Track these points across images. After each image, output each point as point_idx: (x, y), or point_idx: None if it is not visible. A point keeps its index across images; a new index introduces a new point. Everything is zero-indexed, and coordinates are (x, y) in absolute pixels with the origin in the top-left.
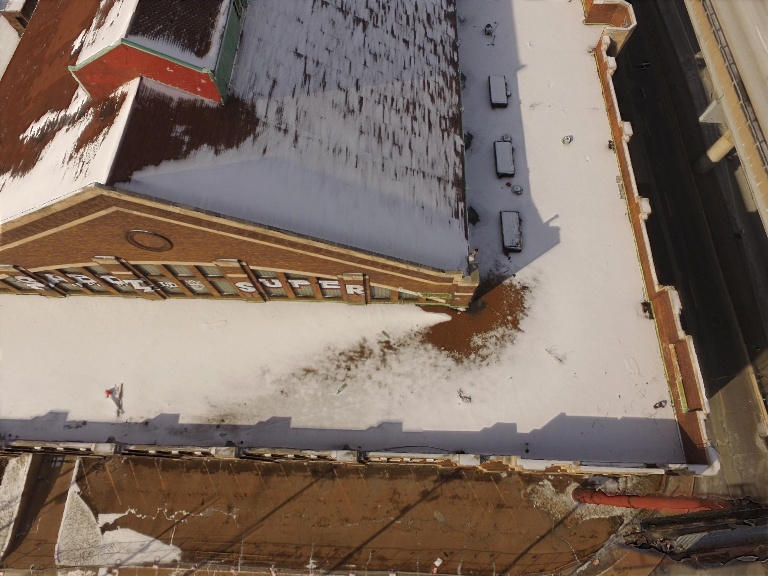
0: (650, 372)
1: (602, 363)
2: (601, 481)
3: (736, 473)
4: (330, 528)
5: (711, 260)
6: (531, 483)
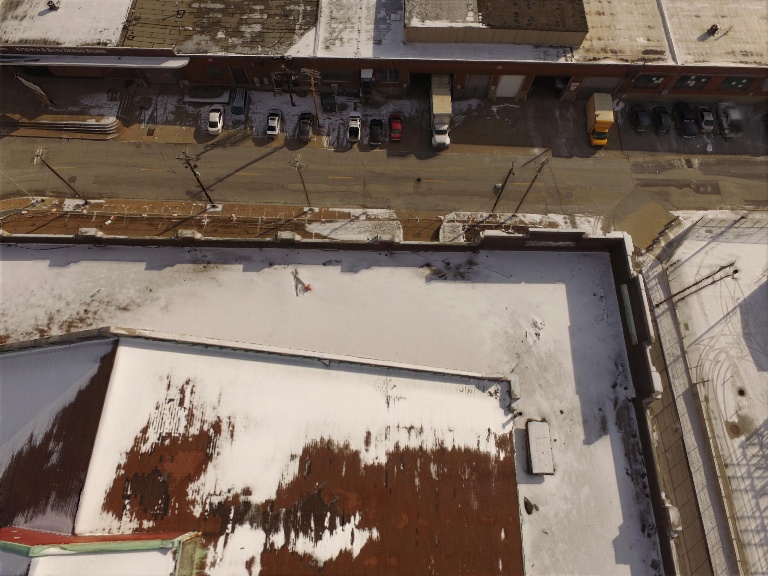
0: None
1: None
2: None
3: None
4: None
5: None
6: None
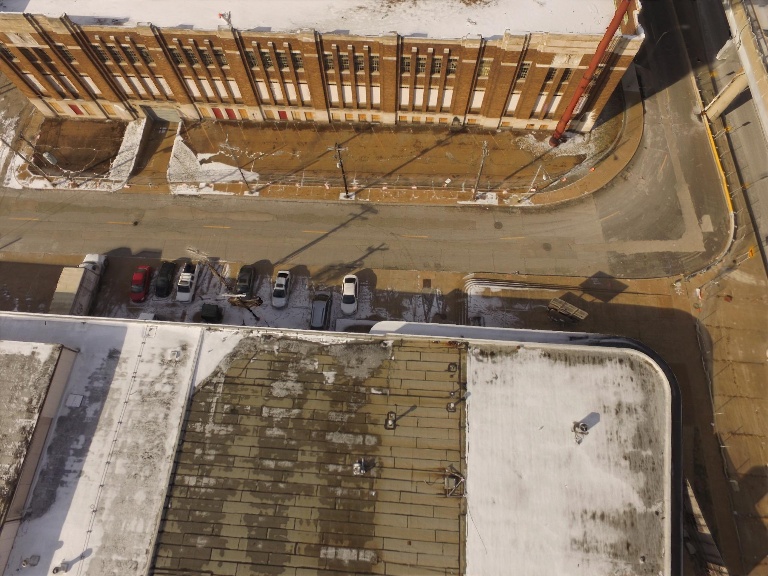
0: (605, 12)
1: (571, 7)
2: (571, 135)
3: (673, 134)
4: (369, 162)
5: (669, 10)
6: (519, 136)
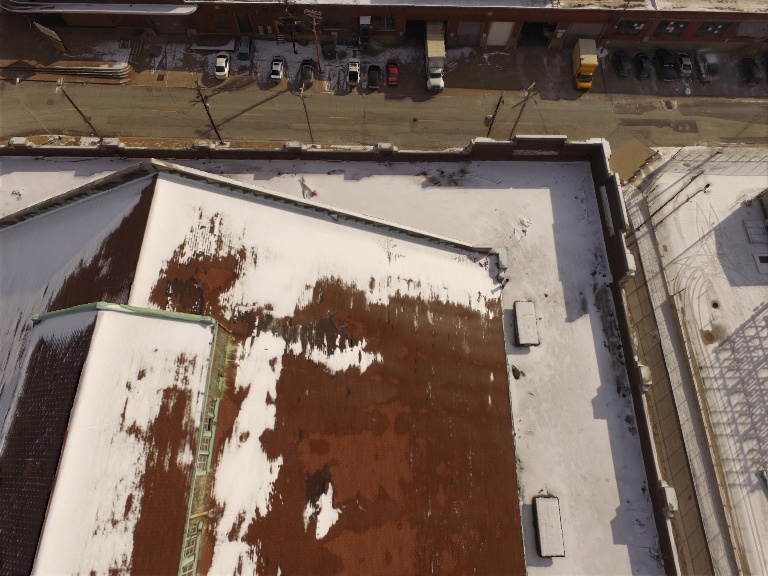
0: None
1: None
2: None
3: None
4: None
5: None
6: None
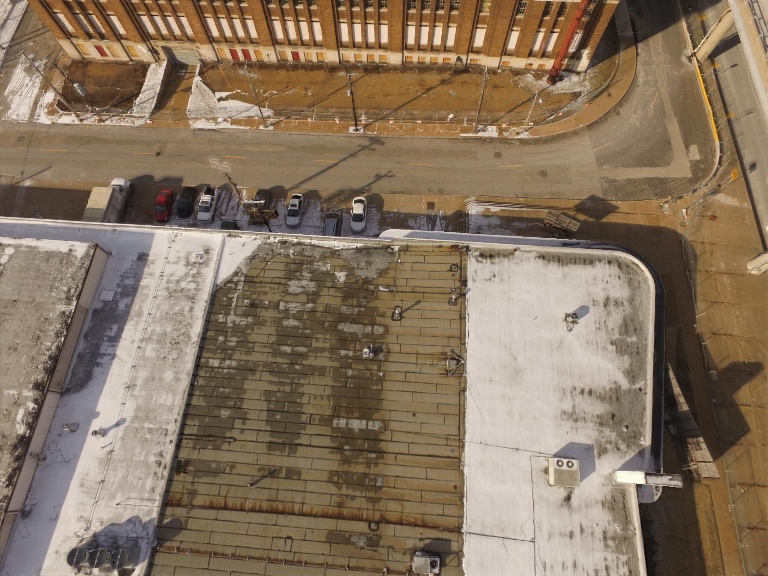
0: None
1: None
2: (568, 75)
3: (664, 74)
4: (376, 99)
5: None
6: (518, 75)
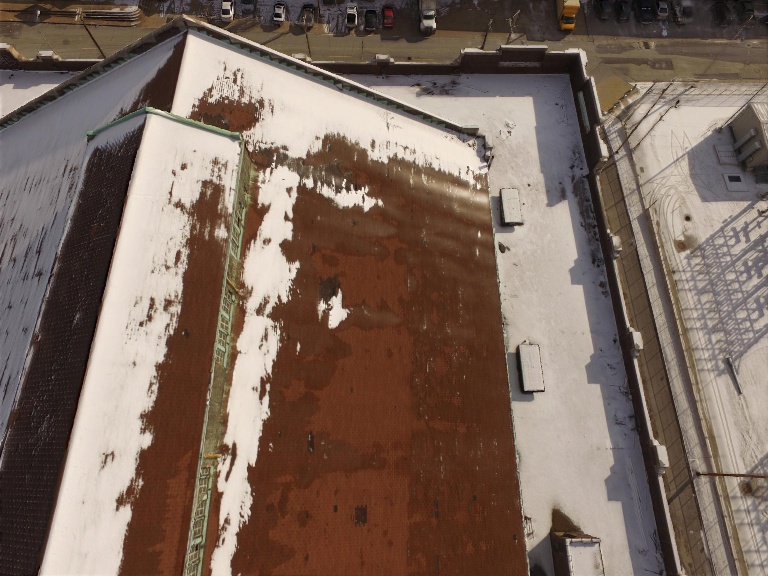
0: None
1: None
2: None
3: None
4: None
5: None
6: None
